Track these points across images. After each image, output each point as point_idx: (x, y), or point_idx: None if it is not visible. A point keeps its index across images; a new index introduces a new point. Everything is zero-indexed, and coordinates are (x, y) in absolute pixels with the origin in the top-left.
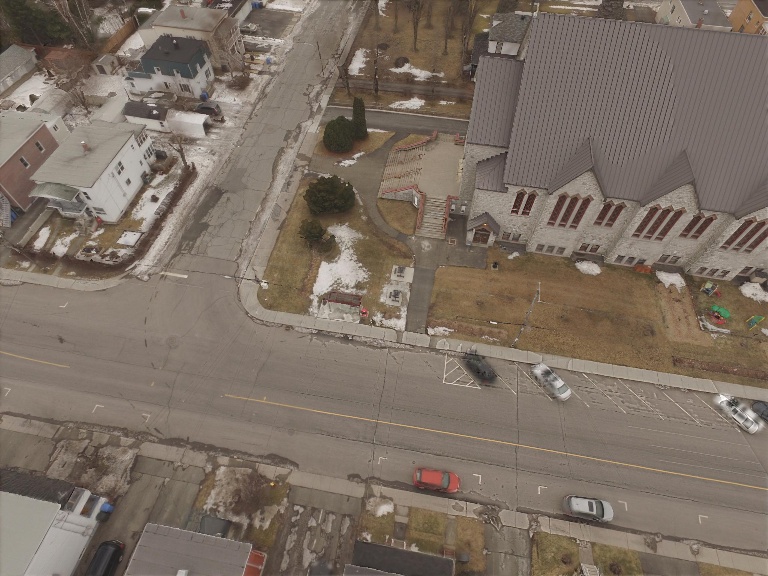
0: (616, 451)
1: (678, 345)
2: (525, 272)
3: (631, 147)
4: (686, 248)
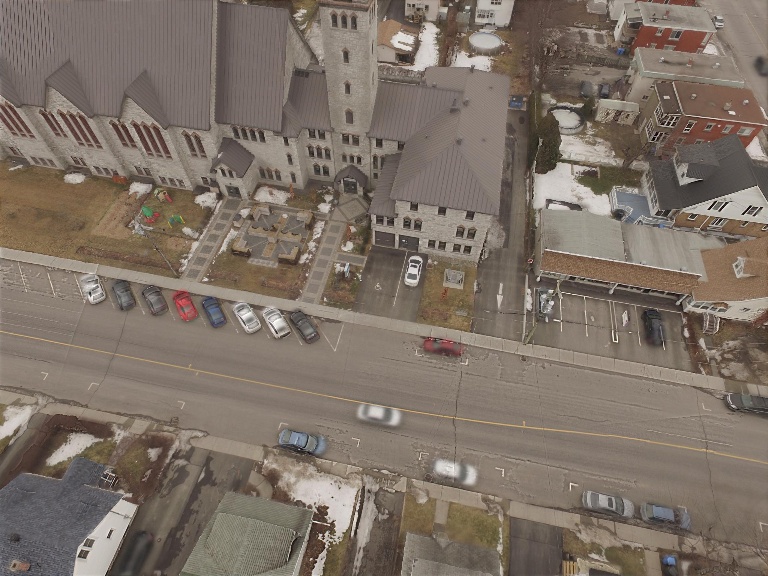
0: None
1: (95, 238)
2: (13, 180)
3: (28, 58)
4: (142, 159)
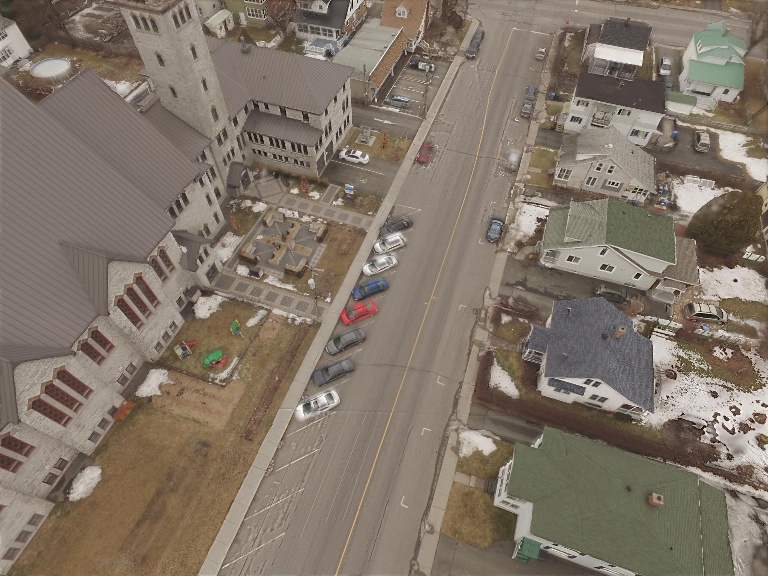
0: (323, 572)
1: (231, 423)
2: None
3: None
4: (121, 357)
